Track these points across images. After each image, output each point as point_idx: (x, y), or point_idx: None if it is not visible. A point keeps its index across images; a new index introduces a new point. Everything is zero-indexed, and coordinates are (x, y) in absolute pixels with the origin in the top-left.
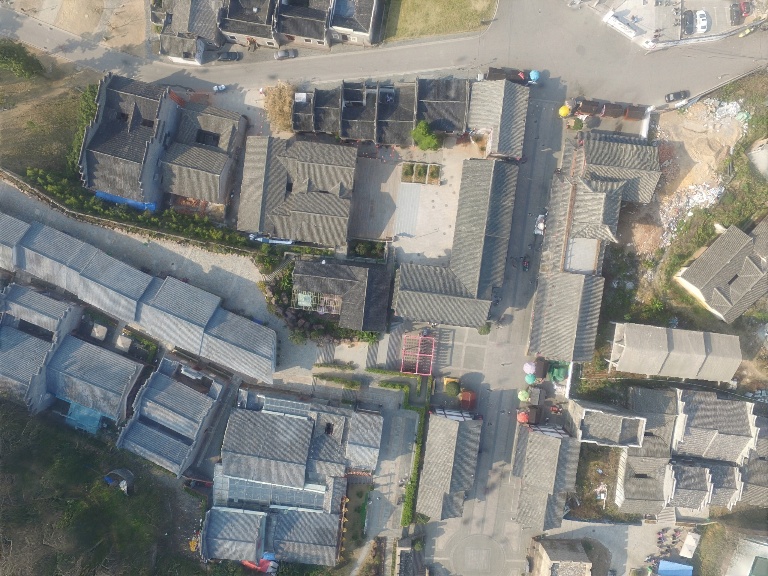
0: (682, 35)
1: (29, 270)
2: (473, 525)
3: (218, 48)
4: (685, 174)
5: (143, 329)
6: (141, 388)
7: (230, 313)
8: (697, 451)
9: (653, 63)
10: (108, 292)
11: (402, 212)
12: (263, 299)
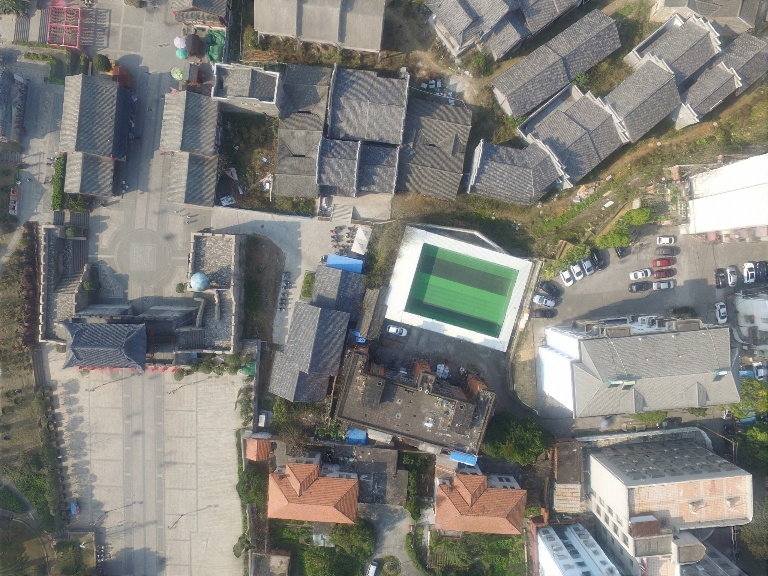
0: None
1: None
2: (137, 219)
3: None
4: None
5: None
6: None
7: None
8: (359, 133)
9: None
10: None
11: None
12: None
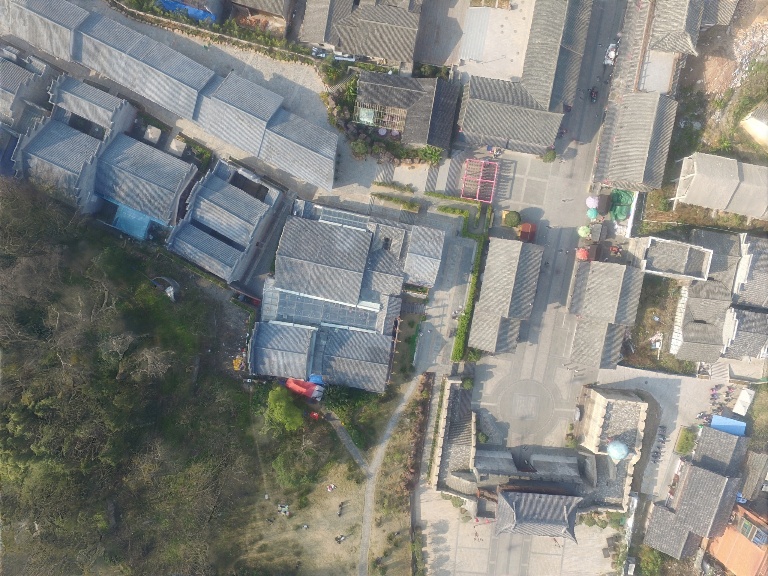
0: None
1: (84, 62)
2: (523, 370)
3: None
4: (760, 9)
5: (197, 137)
6: (197, 182)
7: (293, 114)
8: (757, 300)
9: None
10: (168, 81)
11: (469, 38)
12: (324, 111)
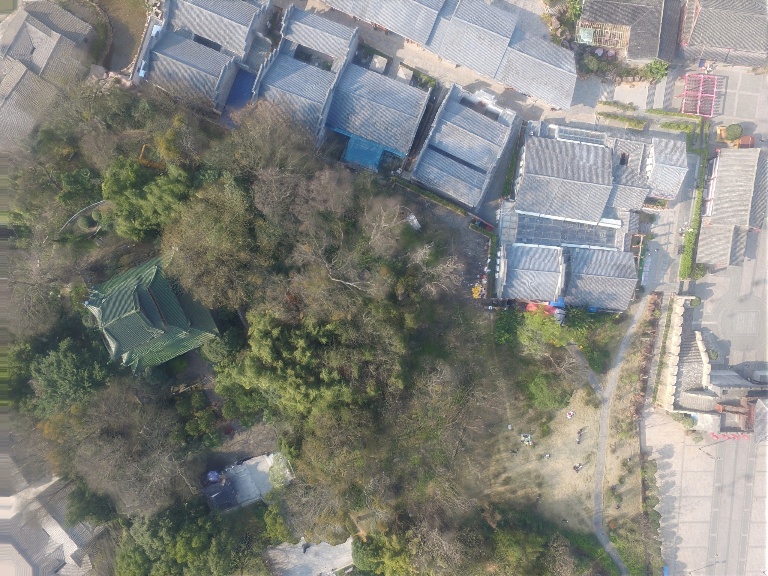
0: None
1: None
2: (742, 286)
3: None
4: None
5: (419, 66)
6: (443, 104)
7: (527, 33)
8: None
9: None
10: (406, 4)
11: None
12: (547, 32)
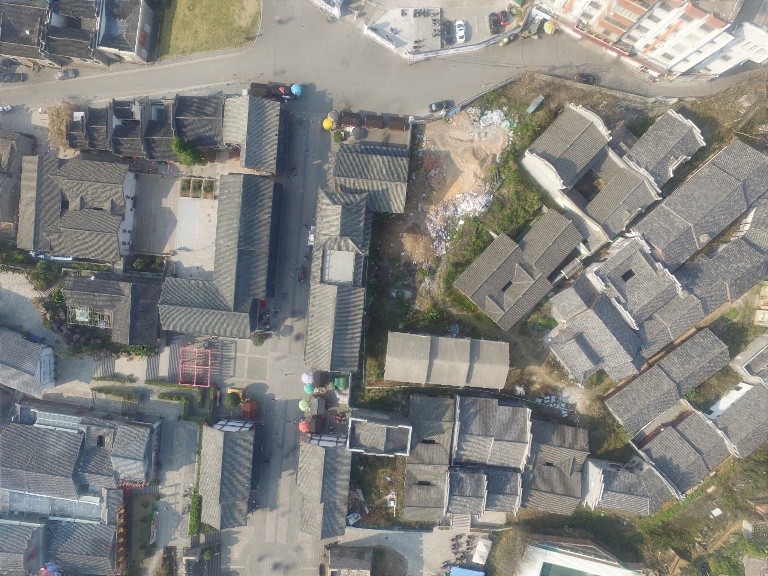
0: (443, 45)
1: None
2: (266, 533)
3: (5, 70)
4: (452, 183)
5: None
6: None
7: None
8: (481, 458)
9: (416, 74)
10: None
11: (182, 226)
12: (40, 315)
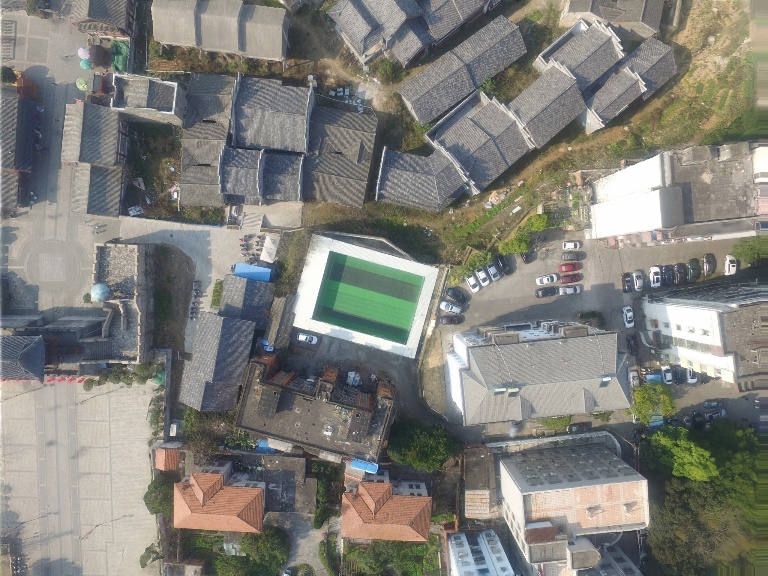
0: None
1: None
2: (46, 230)
3: None
4: None
5: None
6: None
7: None
8: (264, 141)
9: None
10: None
11: None
12: None
